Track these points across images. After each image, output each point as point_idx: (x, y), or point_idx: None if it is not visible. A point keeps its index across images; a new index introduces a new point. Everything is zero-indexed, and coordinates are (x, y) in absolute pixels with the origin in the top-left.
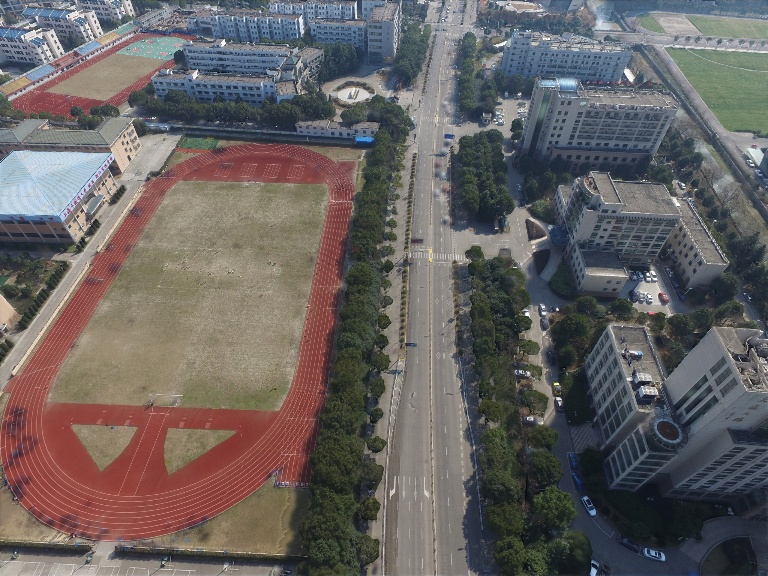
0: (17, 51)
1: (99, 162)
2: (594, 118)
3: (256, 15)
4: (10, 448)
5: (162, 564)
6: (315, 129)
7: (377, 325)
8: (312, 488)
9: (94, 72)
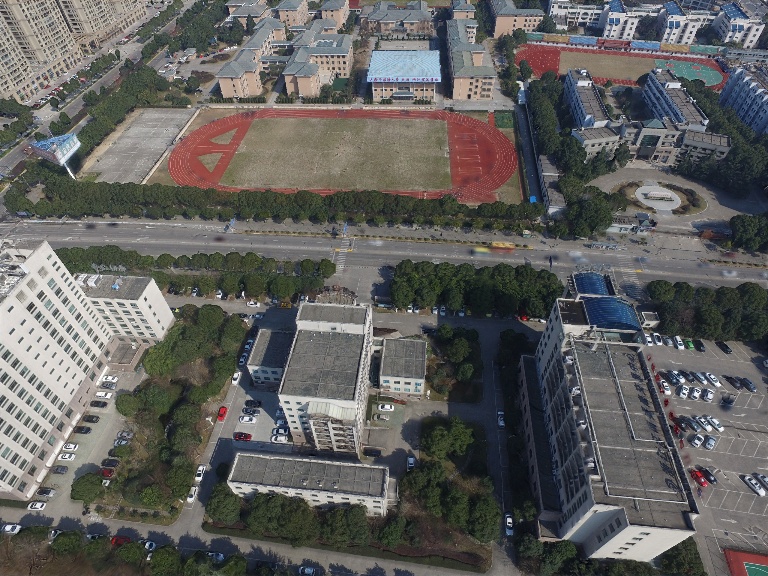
0: None
1: (428, 75)
2: (560, 373)
3: None
4: (232, 117)
5: None
6: None
7: None
8: None
9: (608, 59)
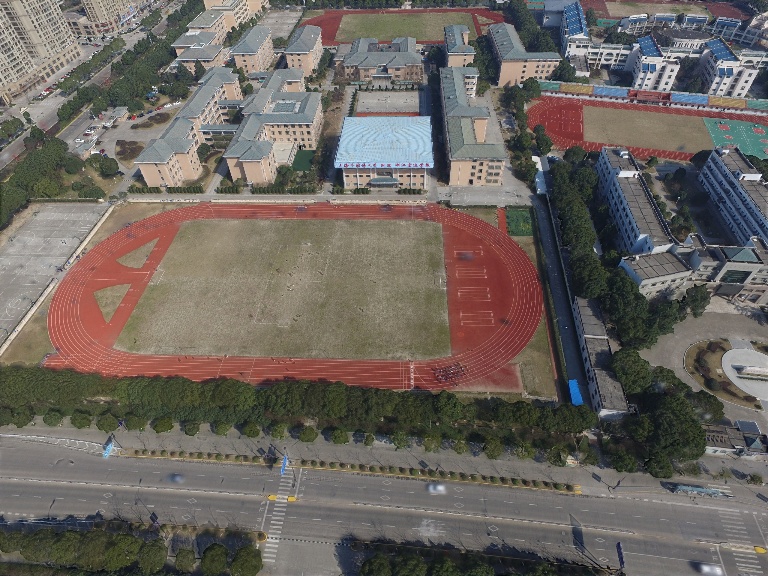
0: None
1: (416, 159)
2: None
3: None
4: (155, 218)
5: (33, 302)
6: (580, 323)
7: None
8: (2, 367)
9: (644, 118)
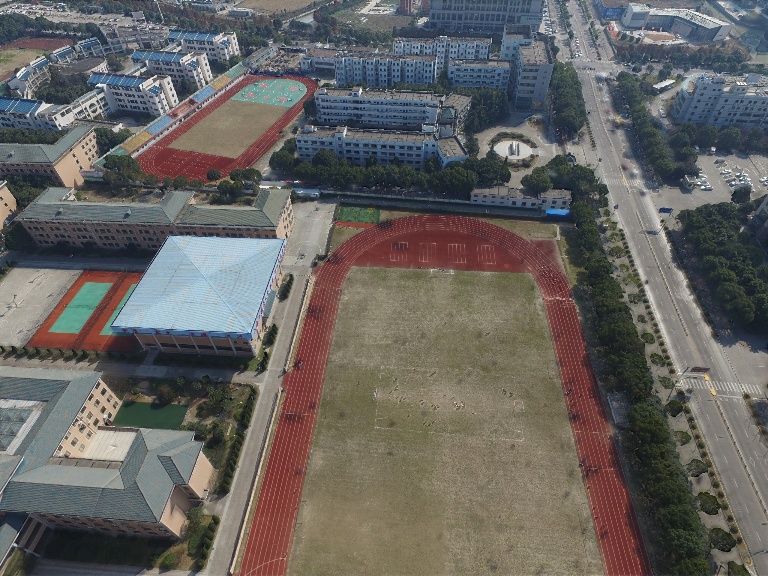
0: (131, 100)
1: (274, 252)
2: None
3: (386, 57)
4: None
5: None
6: (493, 198)
7: (698, 507)
8: None
9: (214, 122)
